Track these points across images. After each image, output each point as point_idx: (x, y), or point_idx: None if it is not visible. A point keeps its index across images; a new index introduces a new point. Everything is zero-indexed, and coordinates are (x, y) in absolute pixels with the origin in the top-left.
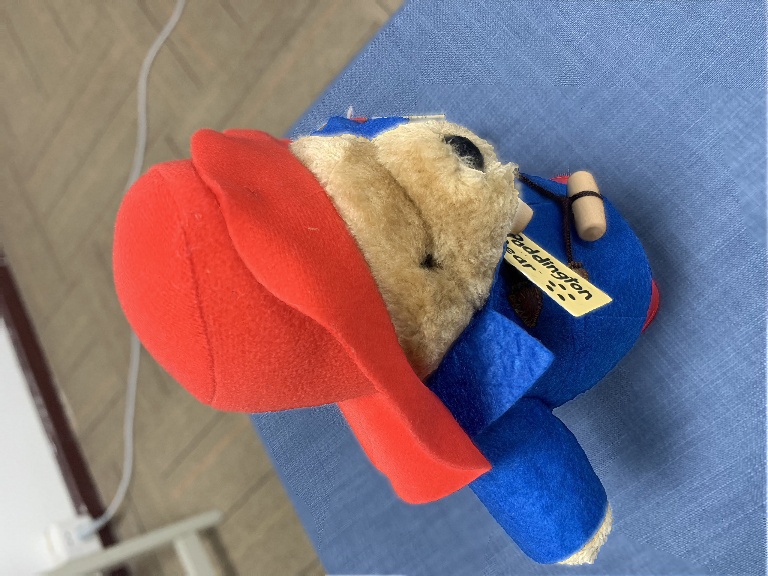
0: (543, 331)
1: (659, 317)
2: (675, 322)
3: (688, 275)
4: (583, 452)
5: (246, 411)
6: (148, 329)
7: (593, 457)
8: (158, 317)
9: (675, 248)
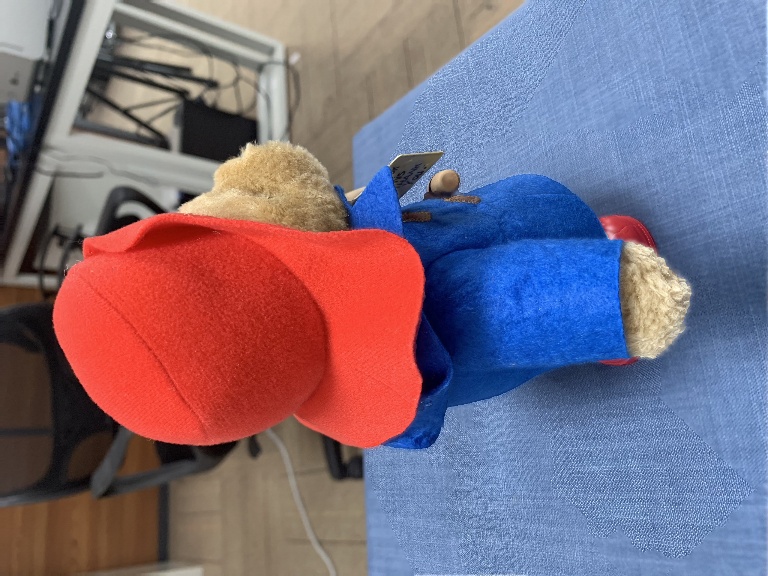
0: None
1: (649, 225)
2: (660, 212)
3: (627, 187)
4: None
5: (209, 379)
6: (94, 362)
7: (761, 354)
8: (84, 332)
9: (601, 190)
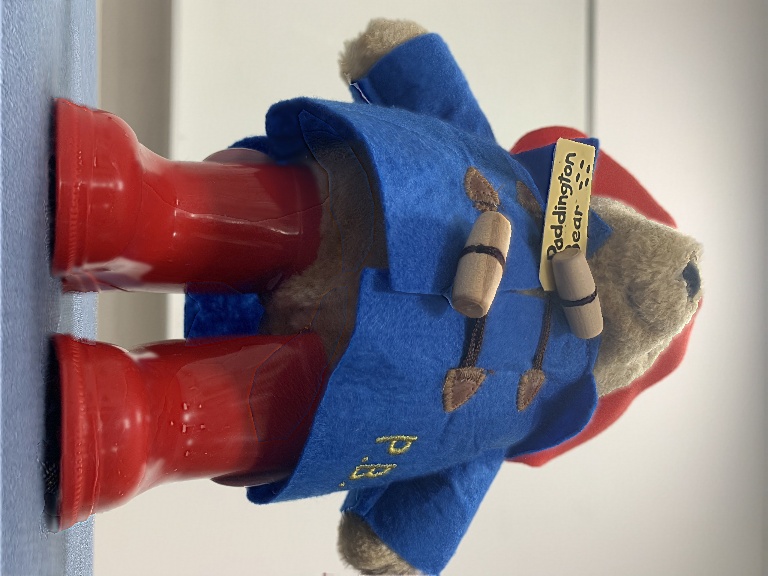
0: (510, 173)
1: None
2: None
3: None
4: (431, 79)
5: None
6: None
7: None
8: None
9: None
